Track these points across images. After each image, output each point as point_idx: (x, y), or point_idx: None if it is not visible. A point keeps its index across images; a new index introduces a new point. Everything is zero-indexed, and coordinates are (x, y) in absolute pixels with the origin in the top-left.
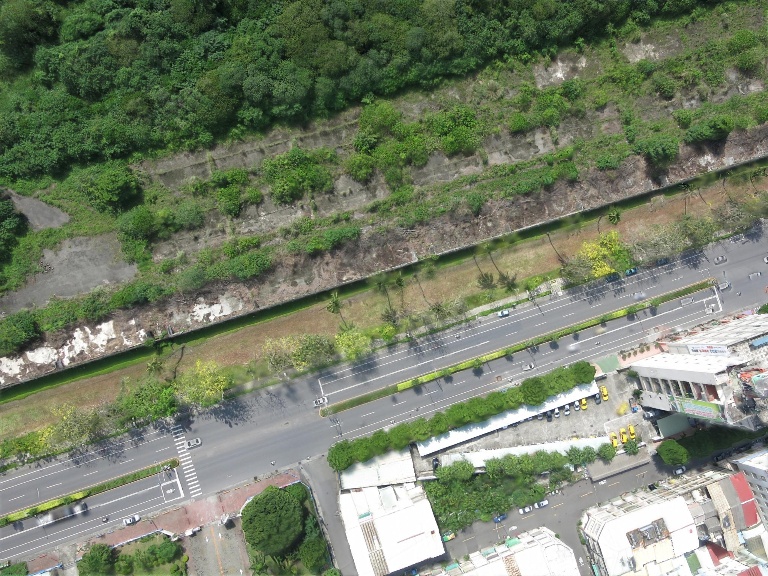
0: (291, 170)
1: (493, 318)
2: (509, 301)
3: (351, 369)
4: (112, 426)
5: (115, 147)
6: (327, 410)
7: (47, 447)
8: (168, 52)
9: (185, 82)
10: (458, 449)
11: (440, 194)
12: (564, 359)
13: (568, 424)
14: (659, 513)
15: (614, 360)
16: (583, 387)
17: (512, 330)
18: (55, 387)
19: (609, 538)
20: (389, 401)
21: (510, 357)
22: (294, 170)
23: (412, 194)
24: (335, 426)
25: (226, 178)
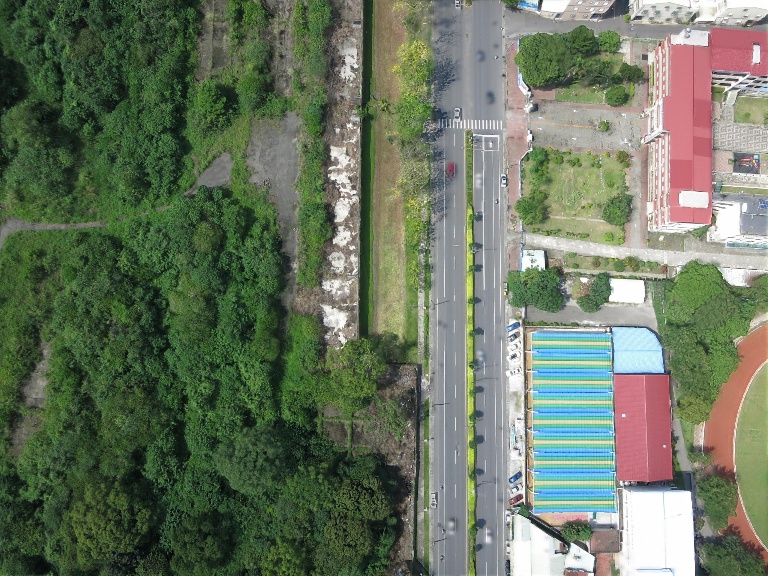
0: None
1: None
2: None
3: None
4: None
5: (176, 88)
6: None
7: None
8: (102, 5)
9: (134, 7)
10: None
11: None
12: None
13: None
14: None
15: None
16: None
17: None
18: (372, 209)
19: None
20: None
21: None
22: None
23: None
24: None
25: None
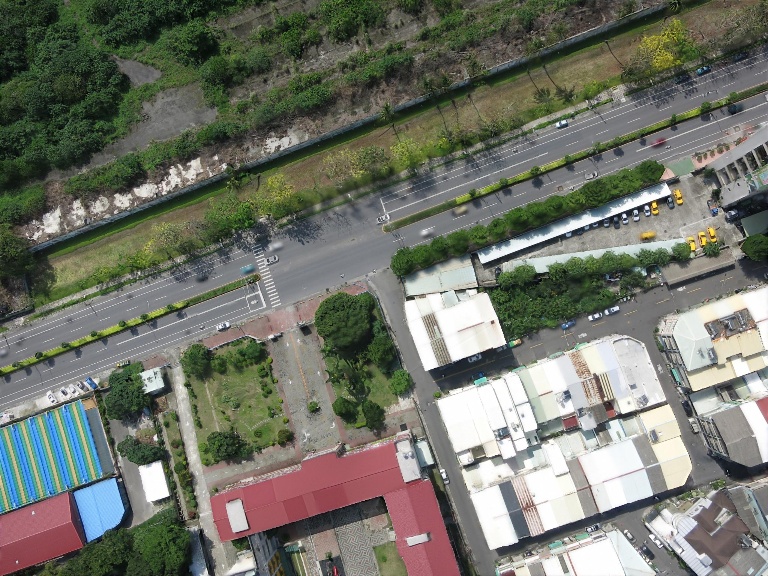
0: (345, 8)
1: (551, 130)
2: (567, 112)
3: (411, 188)
4: (201, 238)
5: (193, 6)
6: (389, 226)
7: (153, 266)
8: None
9: None
10: (520, 259)
11: (490, 15)
12: (631, 165)
13: (638, 230)
14: (742, 303)
15: (688, 163)
16: (653, 190)
17: (572, 140)
18: (157, 217)
19: (684, 329)
20: (449, 215)
21: (571, 167)
22: (348, 7)
23: (461, 17)
24: (398, 241)
25: (288, 23)
